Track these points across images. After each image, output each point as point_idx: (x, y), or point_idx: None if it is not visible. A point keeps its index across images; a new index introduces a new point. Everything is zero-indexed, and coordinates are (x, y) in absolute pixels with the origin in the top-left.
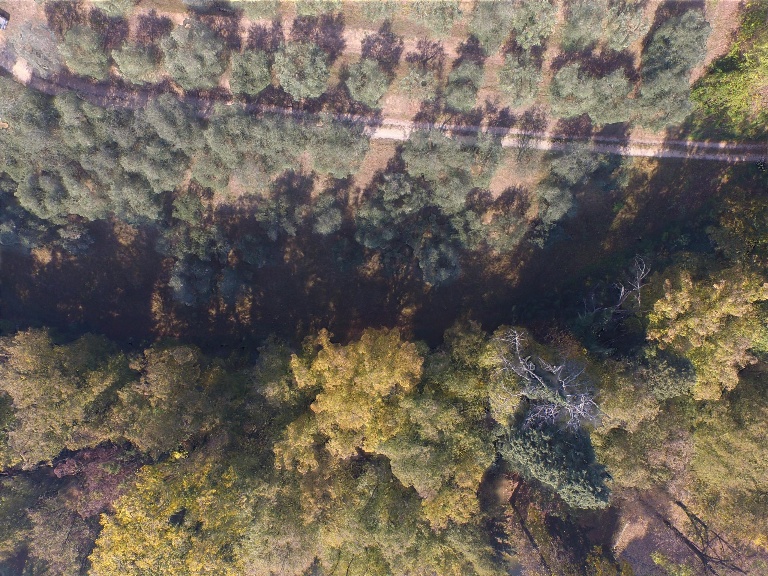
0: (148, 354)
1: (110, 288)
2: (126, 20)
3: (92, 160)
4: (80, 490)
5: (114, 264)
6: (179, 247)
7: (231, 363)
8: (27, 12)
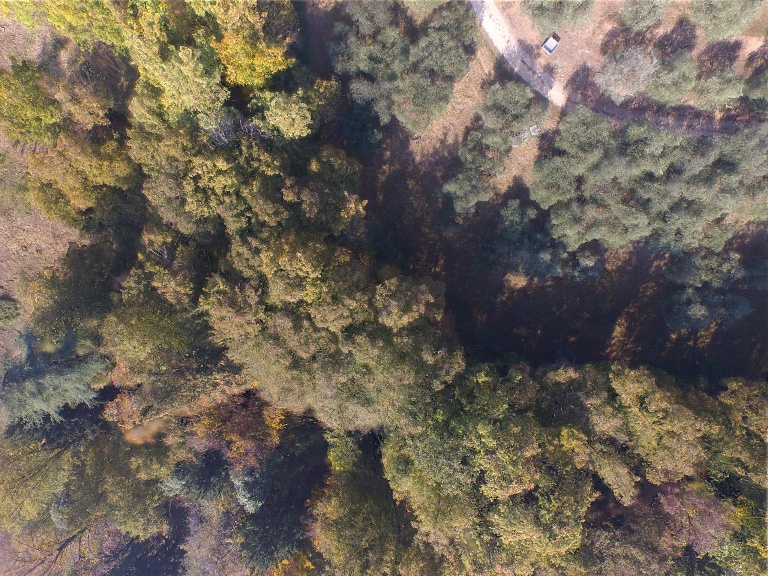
0: (737, 388)
1: (576, 313)
2: (694, 44)
3: (657, 188)
4: (639, 523)
5: (588, 289)
6: (699, 274)
7: (702, 389)
8: (580, 36)
